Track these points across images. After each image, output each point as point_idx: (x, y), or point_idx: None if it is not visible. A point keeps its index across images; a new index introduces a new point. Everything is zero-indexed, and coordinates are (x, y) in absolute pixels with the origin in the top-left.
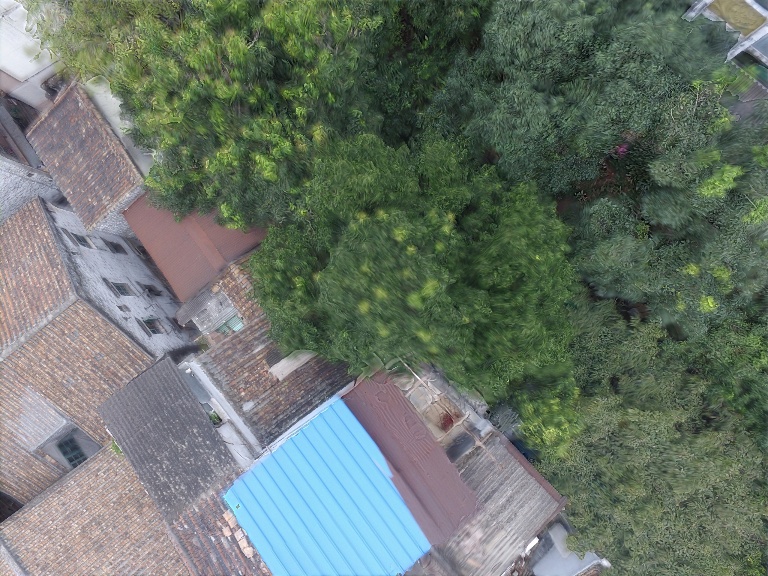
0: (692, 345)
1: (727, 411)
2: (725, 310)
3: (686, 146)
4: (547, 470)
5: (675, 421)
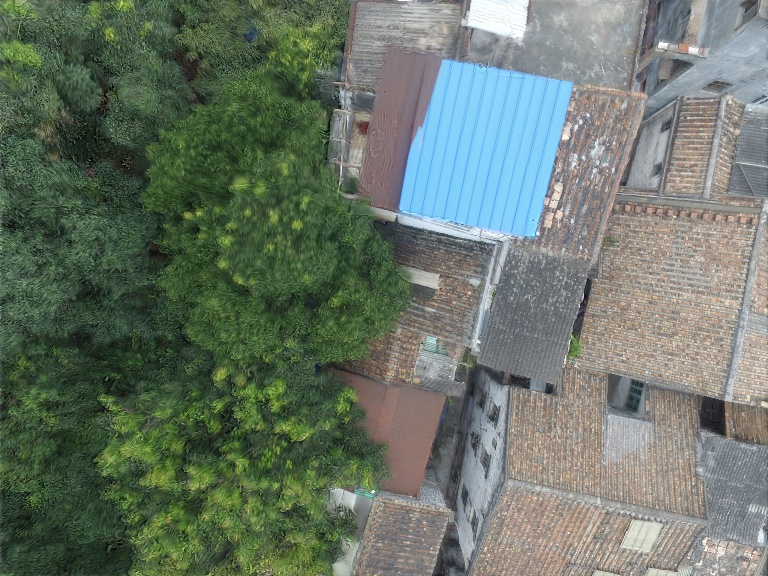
0: (179, 3)
1: None
2: None
3: (15, 105)
4: None
5: None
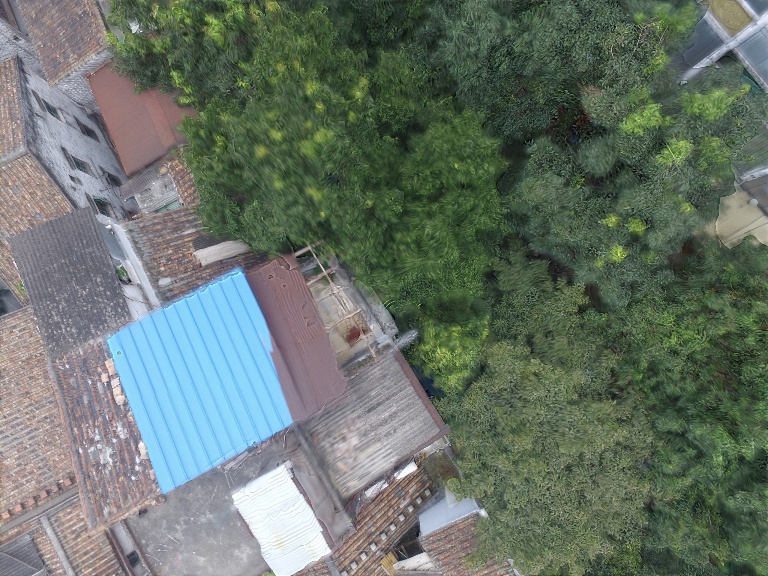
0: (613, 321)
1: (631, 388)
2: (646, 284)
3: (621, 87)
4: (445, 410)
5: (576, 382)
